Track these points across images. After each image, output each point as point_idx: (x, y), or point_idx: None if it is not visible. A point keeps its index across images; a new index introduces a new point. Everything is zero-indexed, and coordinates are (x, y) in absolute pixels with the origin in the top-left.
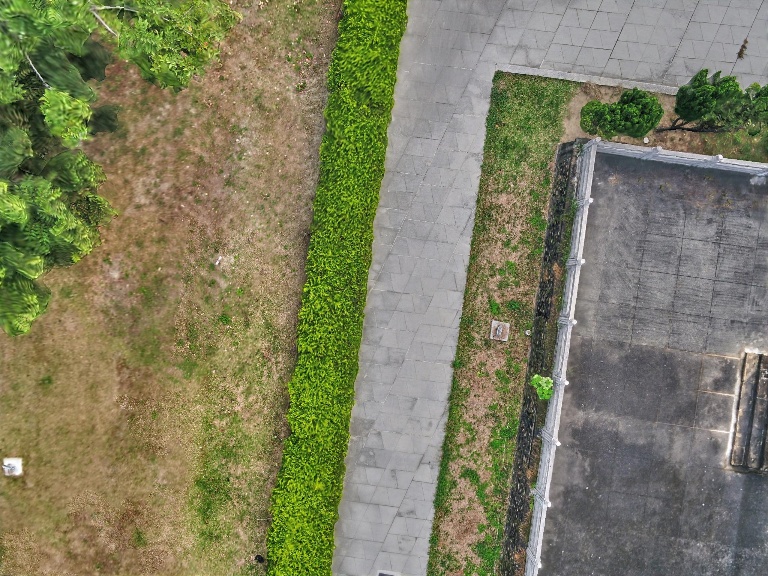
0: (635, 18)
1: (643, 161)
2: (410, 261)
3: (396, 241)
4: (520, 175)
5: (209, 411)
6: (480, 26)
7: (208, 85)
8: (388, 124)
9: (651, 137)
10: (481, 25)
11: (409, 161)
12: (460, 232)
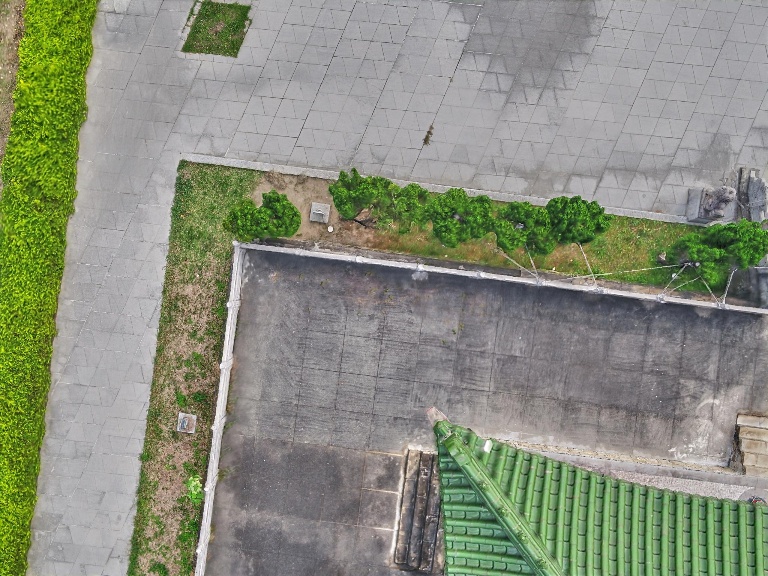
0: (320, 105)
1: (303, 258)
2: (96, 353)
3: (82, 333)
4: (205, 265)
5: None
6: (164, 115)
7: None
8: (71, 215)
9: (336, 225)
10: (165, 114)
11: (94, 252)
12: (146, 323)
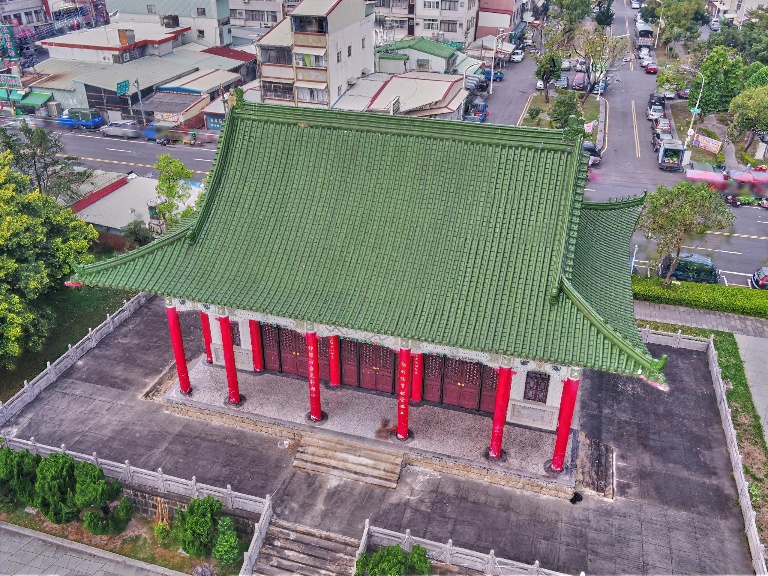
0: None
1: None
2: None
3: None
4: None
5: None
6: None
7: None
8: None
9: None
10: None
11: None
12: None
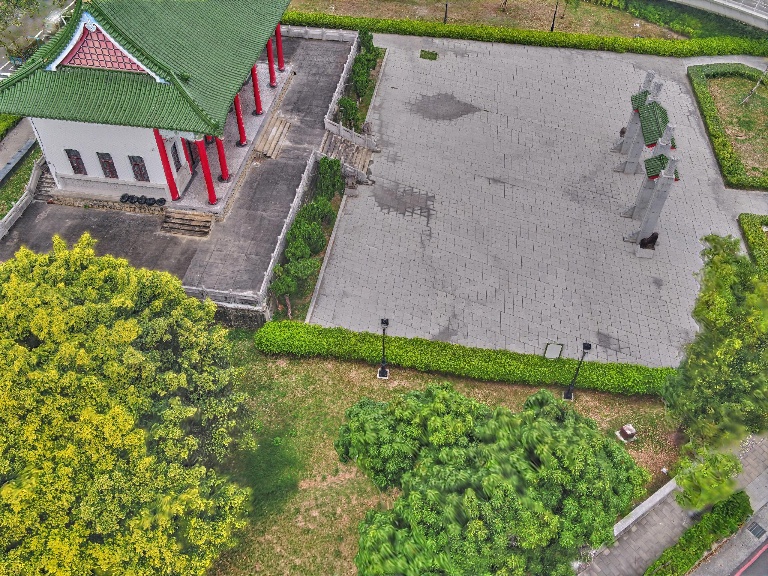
0: None
1: None
2: None
3: None
4: None
5: (290, 8)
6: None
7: (383, 8)
8: None
9: None
10: None
11: None
12: None
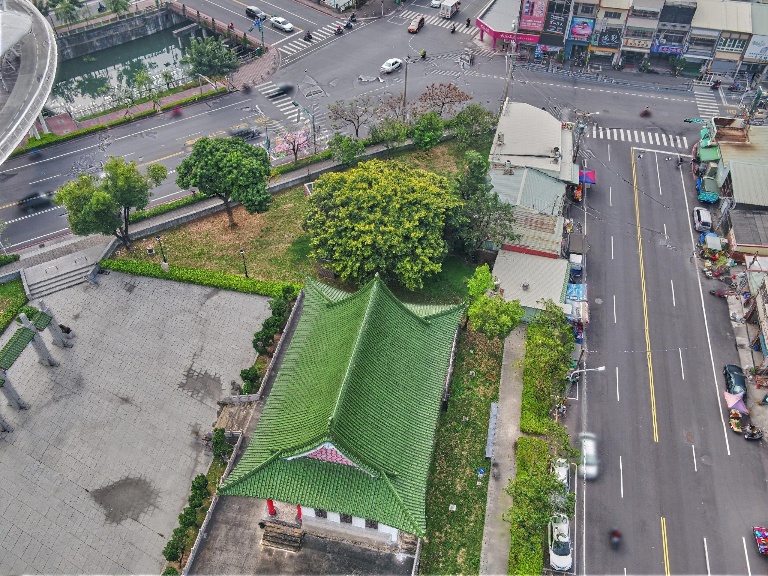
0: (137, 573)
1: (188, 574)
2: None
3: None
4: None
5: None
6: None
7: None
8: None
9: (182, 570)
10: None
11: None
12: None
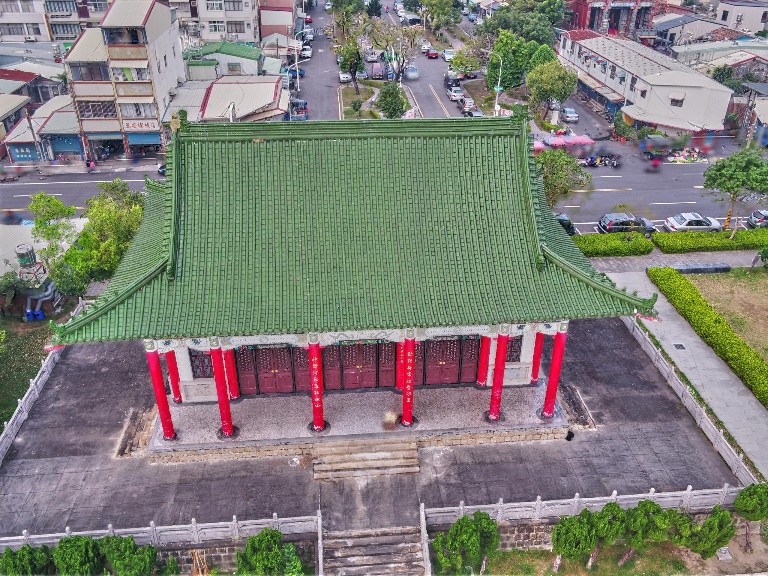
0: None
1: None
2: None
3: None
4: None
5: None
6: None
7: None
8: None
9: None
10: None
11: None
12: None
